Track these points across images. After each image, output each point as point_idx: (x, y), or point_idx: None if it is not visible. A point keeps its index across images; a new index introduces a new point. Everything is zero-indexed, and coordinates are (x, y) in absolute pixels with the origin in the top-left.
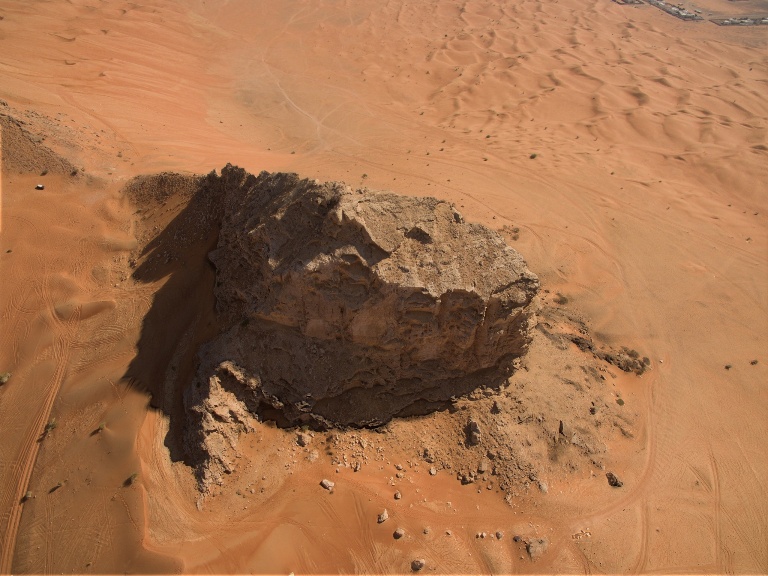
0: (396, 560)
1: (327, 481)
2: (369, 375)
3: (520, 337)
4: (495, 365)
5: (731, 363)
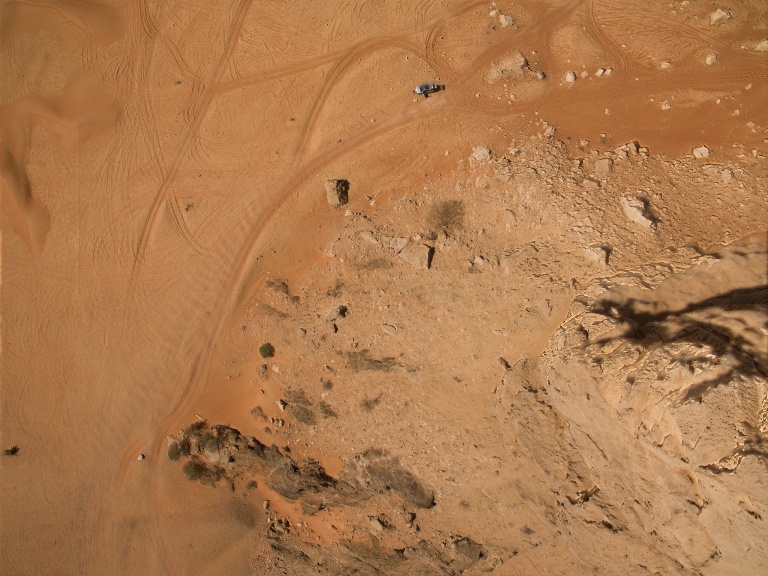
0: (761, 18)
1: None
2: None
3: None
4: None
5: (1, 463)
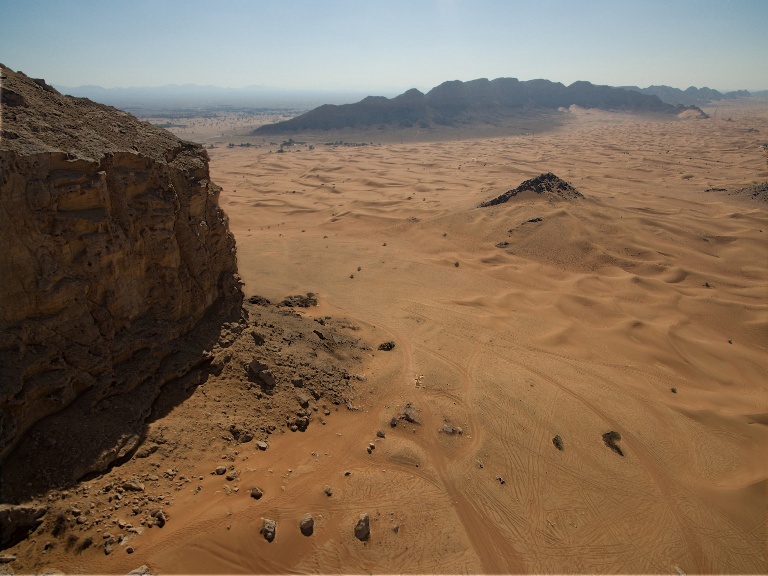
0: (338, 556)
1: (127, 574)
2: (54, 374)
3: (223, 235)
4: (218, 297)
5: None
